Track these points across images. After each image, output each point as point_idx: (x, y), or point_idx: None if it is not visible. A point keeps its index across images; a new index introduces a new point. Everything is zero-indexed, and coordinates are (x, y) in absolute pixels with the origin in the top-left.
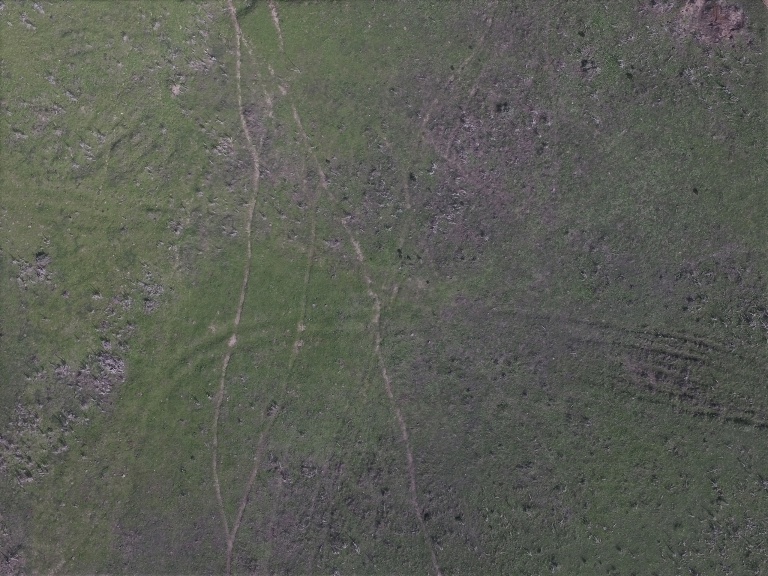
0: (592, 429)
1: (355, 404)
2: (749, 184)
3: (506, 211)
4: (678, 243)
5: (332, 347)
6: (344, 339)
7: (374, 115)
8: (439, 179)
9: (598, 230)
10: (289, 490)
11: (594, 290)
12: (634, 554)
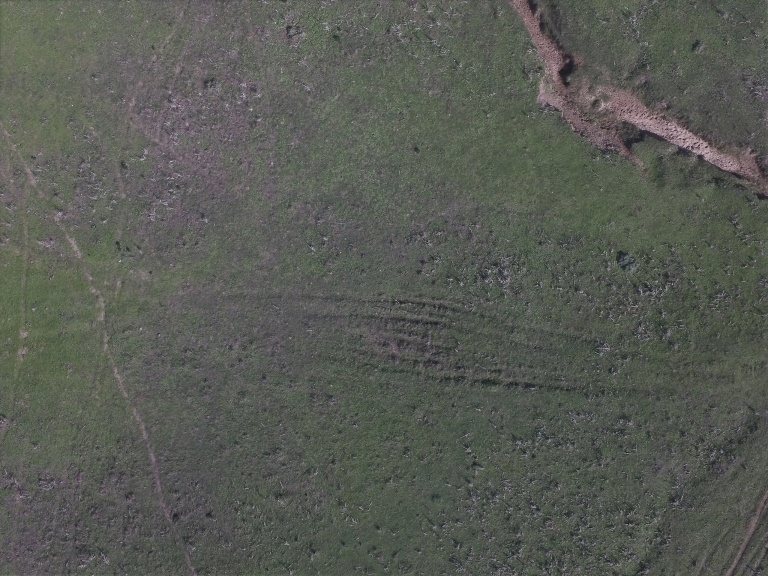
0: (338, 406)
1: (88, 408)
2: (470, 137)
3: (225, 190)
4: (405, 205)
5: (58, 351)
6: (69, 341)
7: (77, 105)
8: (152, 164)
9: (322, 200)
10: (28, 506)
11: (324, 263)
12: (394, 531)
